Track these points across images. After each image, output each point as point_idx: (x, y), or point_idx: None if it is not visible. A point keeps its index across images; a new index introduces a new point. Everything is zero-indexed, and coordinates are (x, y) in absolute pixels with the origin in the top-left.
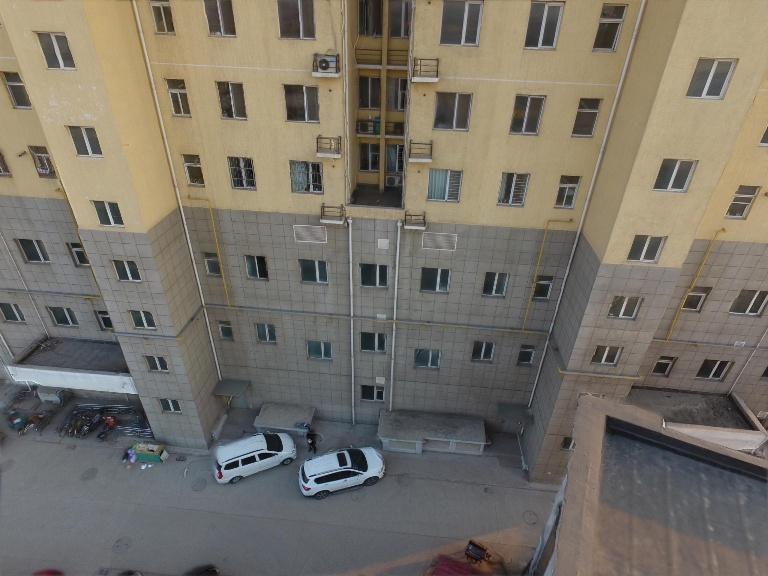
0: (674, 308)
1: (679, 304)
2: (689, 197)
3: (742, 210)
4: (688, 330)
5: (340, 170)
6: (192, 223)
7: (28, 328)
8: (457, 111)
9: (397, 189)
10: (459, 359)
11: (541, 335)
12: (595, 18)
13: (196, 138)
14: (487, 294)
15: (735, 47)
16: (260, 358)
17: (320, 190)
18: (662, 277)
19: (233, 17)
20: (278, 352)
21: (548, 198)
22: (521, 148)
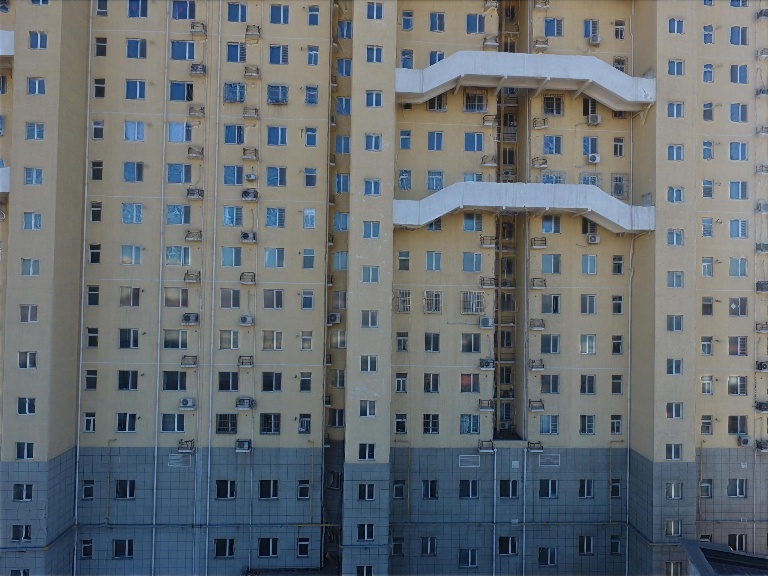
0: (696, 496)
1: (698, 493)
2: (685, 421)
3: (708, 429)
4: (710, 512)
5: (490, 419)
6: (393, 459)
7: (234, 562)
8: (552, 384)
9: (508, 430)
10: (570, 554)
11: (622, 526)
12: (610, 341)
13: (407, 404)
14: (582, 497)
15: (679, 354)
16: (421, 571)
17: (477, 432)
18: (687, 468)
19: (438, 343)
20: (437, 563)
21: (607, 428)
22: (588, 401)
